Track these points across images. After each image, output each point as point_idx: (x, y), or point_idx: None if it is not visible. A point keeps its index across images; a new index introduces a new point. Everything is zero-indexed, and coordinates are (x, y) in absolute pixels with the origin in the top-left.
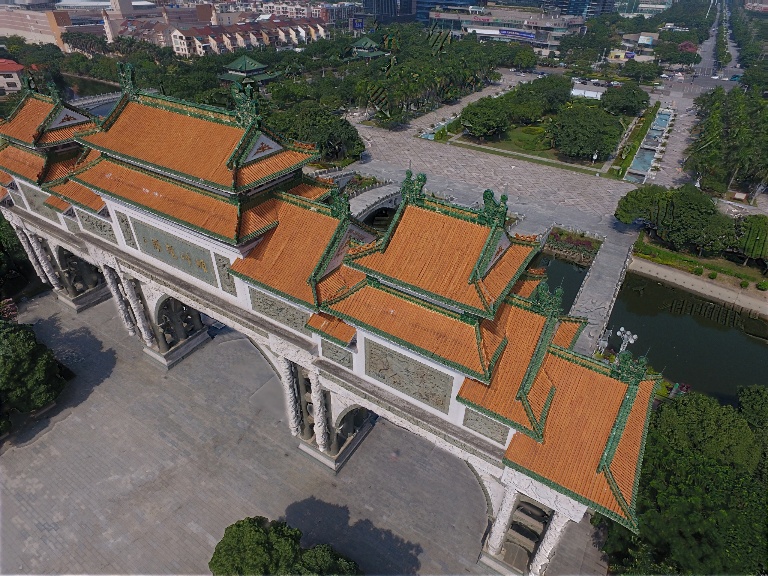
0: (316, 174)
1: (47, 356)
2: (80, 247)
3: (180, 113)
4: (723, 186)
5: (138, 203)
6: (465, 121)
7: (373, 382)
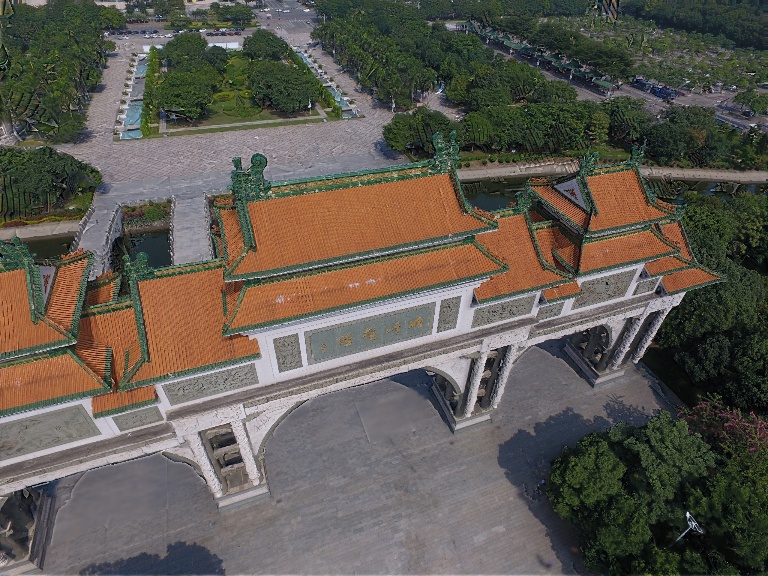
0: (82, 227)
1: None
2: (171, 433)
3: (345, 187)
4: (409, 101)
5: (363, 300)
6: (172, 106)
7: (575, 312)
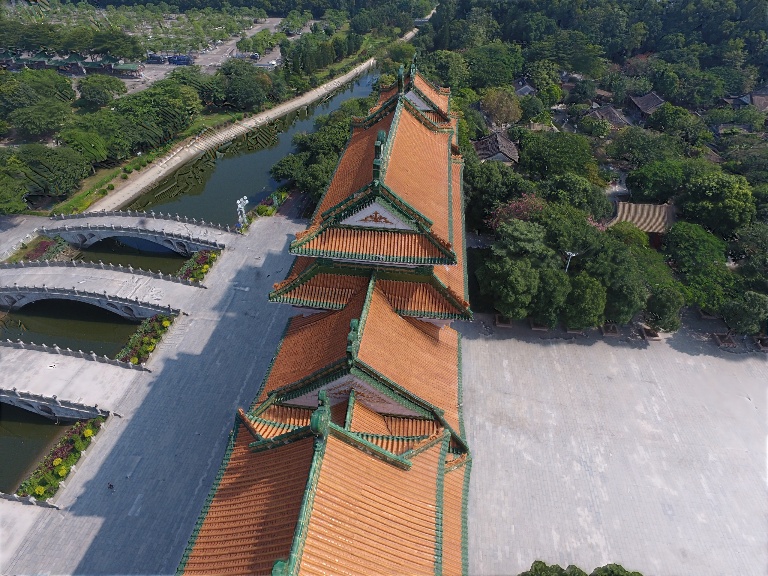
0: None
1: (527, 572)
2: None
3: None
4: None
5: (462, 232)
6: None
7: None
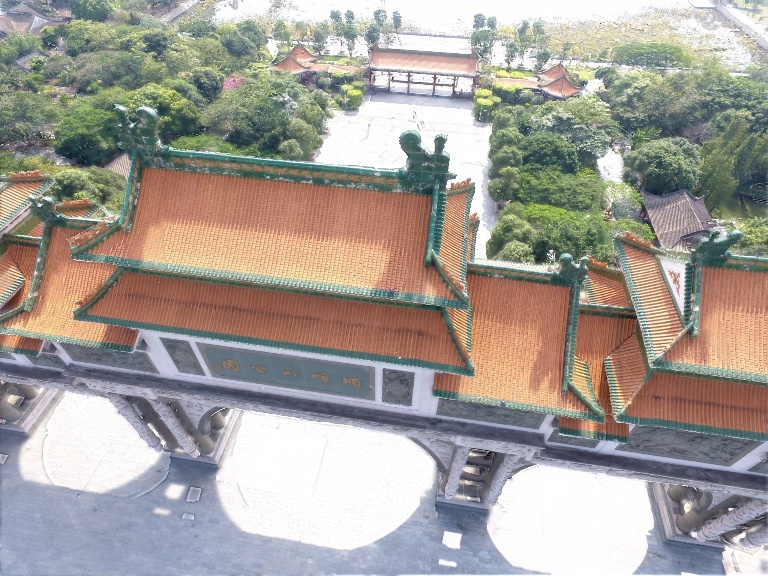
0: None
1: None
2: None
3: None
4: None
5: None
6: None
7: None
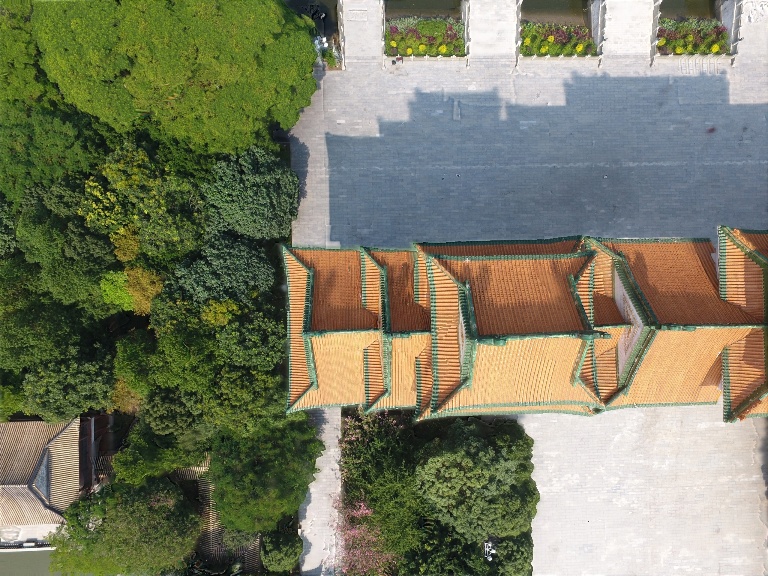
0: None
1: None
2: None
3: None
4: None
5: None
6: None
7: None
